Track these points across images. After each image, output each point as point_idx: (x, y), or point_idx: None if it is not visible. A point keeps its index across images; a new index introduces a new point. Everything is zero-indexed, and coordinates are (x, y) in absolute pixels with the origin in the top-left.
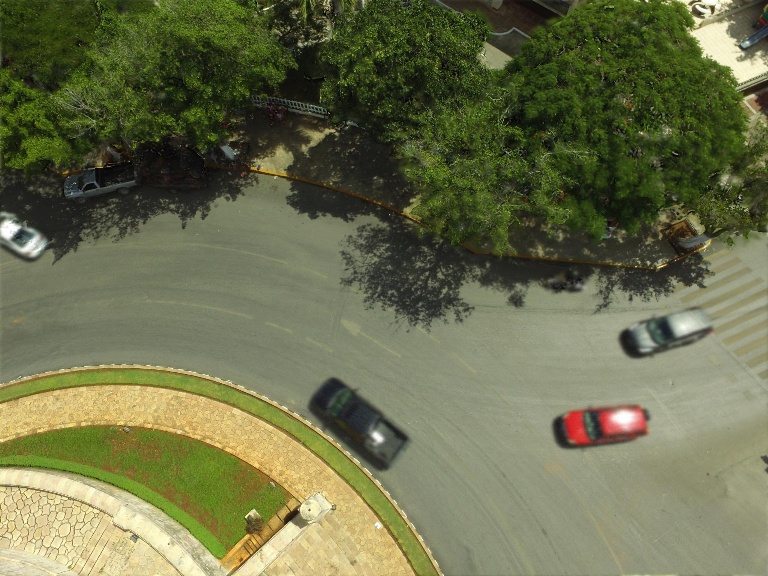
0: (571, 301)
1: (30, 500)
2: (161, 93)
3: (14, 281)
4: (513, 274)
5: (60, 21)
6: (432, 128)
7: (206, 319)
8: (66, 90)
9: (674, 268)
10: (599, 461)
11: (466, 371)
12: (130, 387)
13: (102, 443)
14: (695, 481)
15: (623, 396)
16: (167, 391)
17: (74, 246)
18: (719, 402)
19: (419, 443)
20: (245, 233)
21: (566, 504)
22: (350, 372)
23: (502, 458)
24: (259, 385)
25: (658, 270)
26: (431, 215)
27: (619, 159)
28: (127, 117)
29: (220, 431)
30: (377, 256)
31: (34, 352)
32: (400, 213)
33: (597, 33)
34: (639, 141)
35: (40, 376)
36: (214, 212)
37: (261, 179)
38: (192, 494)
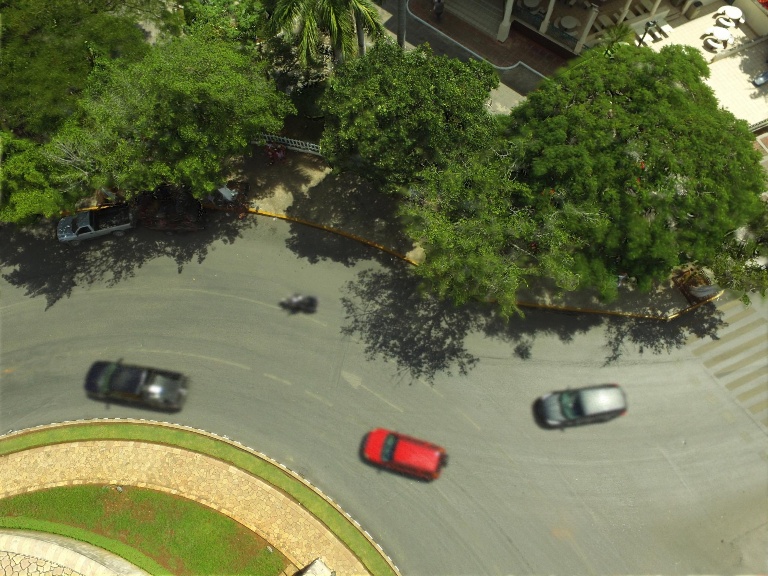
0: (579, 353)
1: (19, 566)
2: (156, 142)
3: (5, 328)
4: (519, 323)
5: (51, 68)
6: (436, 184)
7: (202, 370)
8: (57, 142)
9: (686, 318)
10: (609, 526)
11: (470, 427)
12: (123, 443)
13: (94, 503)
14: (709, 549)
15: (633, 456)
16: (161, 447)
17: (67, 291)
18: (733, 463)
19: (422, 505)
20: (243, 278)
21: (574, 572)
22: (350, 428)
23: (508, 522)
24: (256, 441)
25: (669, 320)
26: (435, 274)
27: (631, 219)
28: (120, 169)
29: (216, 491)
30: (379, 303)
31: (25, 404)
32: (402, 258)
33: (608, 86)
34: (652, 201)
35: (31, 430)
36: (211, 256)
37: (260, 221)
38: (186, 559)
